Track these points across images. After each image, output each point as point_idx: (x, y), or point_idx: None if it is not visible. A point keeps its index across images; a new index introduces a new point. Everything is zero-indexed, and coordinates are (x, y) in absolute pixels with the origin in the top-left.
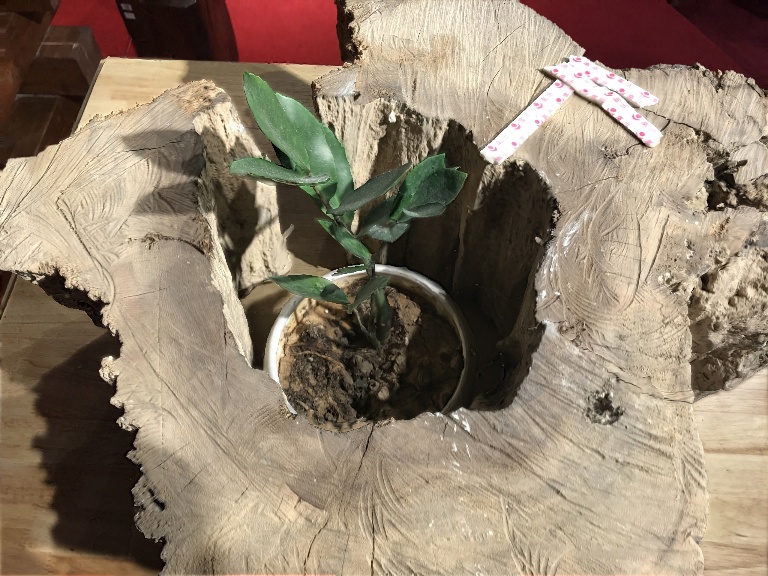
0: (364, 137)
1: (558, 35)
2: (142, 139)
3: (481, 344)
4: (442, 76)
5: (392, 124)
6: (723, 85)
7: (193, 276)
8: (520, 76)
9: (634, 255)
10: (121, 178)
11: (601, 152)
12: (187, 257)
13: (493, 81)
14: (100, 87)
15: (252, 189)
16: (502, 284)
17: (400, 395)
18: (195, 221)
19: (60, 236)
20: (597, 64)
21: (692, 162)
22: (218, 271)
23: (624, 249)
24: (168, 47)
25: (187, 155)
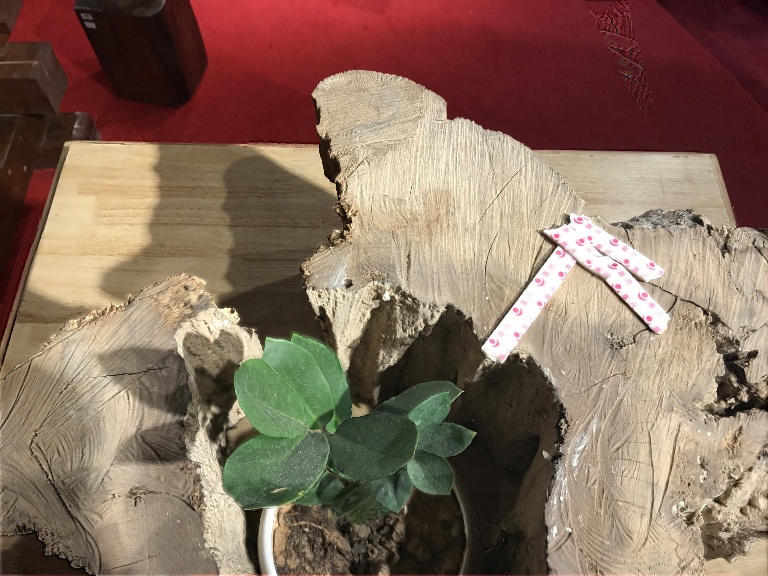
0: (356, 310)
1: (557, 183)
2: (120, 359)
3: (478, 474)
4: (437, 245)
5: (386, 301)
6: (730, 248)
7: (184, 538)
8: (519, 241)
9: (646, 477)
10: (100, 416)
11: (607, 341)
12: (177, 514)
13: (491, 249)
14: (66, 180)
15: (238, 361)
16: (500, 431)
17: (400, 567)
18: (183, 471)
19: (36, 490)
20: (598, 221)
21: (701, 353)
22: (210, 513)
23: (635, 470)
24: (136, 123)
25: (170, 386)
